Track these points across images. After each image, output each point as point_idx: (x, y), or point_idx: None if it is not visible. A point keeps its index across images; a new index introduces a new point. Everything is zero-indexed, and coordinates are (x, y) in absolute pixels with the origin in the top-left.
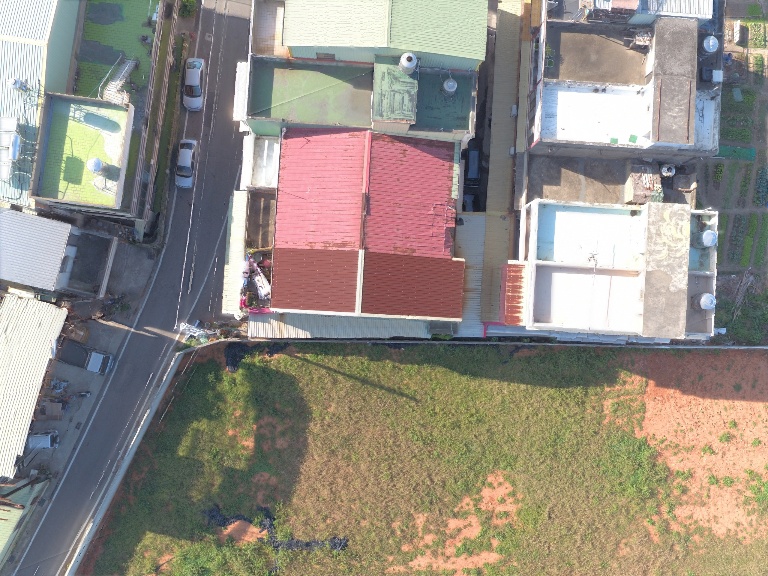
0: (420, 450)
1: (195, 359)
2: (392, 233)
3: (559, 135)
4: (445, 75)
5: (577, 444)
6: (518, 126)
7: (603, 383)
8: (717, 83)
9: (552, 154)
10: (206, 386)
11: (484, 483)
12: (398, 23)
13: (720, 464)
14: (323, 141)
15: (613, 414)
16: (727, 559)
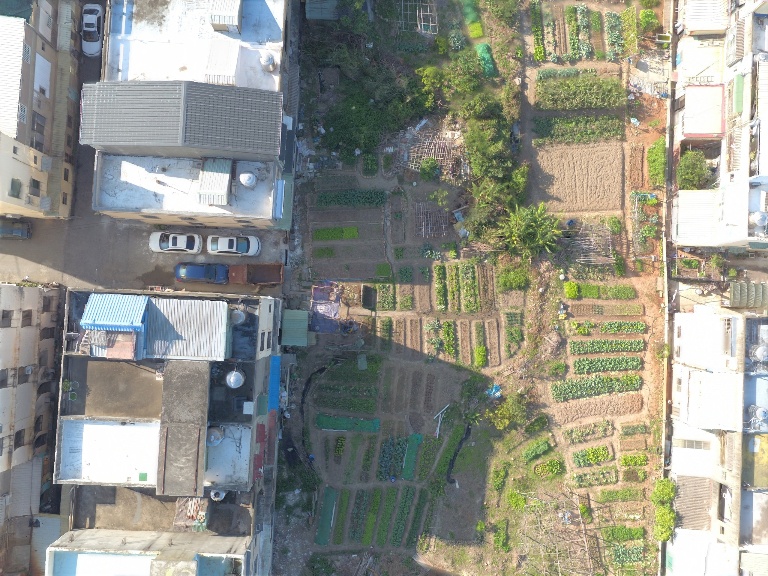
0: None
1: None
2: None
3: (84, 471)
4: None
5: None
6: None
7: None
8: None
9: None
10: None
11: None
12: None
13: None
14: None
15: None
16: None
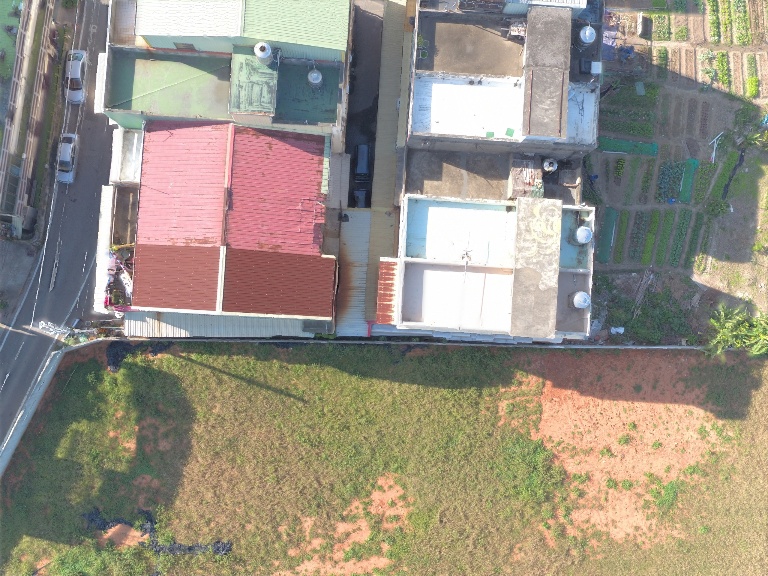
0: (308, 452)
1: (76, 358)
2: (256, 229)
3: (433, 128)
4: (313, 66)
5: (470, 446)
6: (399, 119)
7: (498, 384)
8: (596, 75)
9: (432, 148)
10: (86, 386)
11: (374, 486)
12: (252, 12)
13: (619, 467)
14: (186, 134)
15: (508, 415)
16: (625, 564)
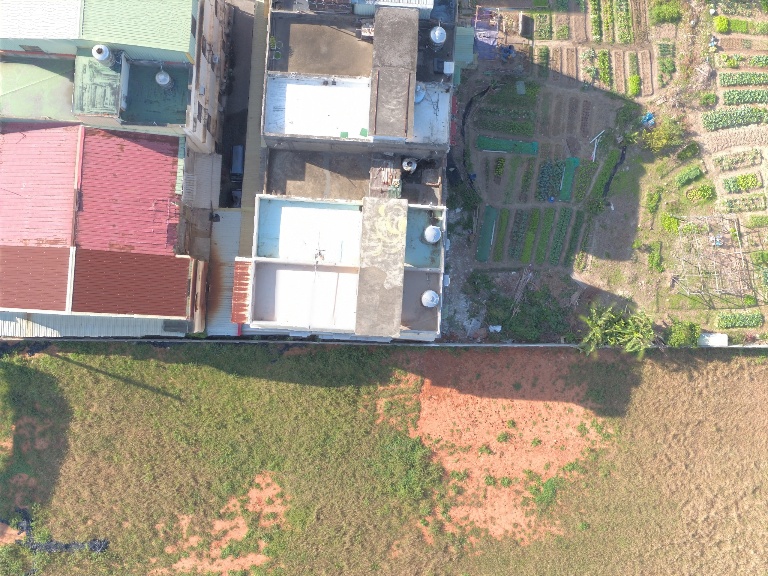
0: (184, 450)
1: None
2: (107, 230)
3: (287, 129)
4: (164, 68)
5: (347, 444)
6: None
7: (376, 382)
8: (450, 75)
9: (294, 148)
10: None
11: (251, 484)
12: (91, 14)
13: (498, 464)
14: (38, 136)
15: (386, 413)
16: (503, 561)
